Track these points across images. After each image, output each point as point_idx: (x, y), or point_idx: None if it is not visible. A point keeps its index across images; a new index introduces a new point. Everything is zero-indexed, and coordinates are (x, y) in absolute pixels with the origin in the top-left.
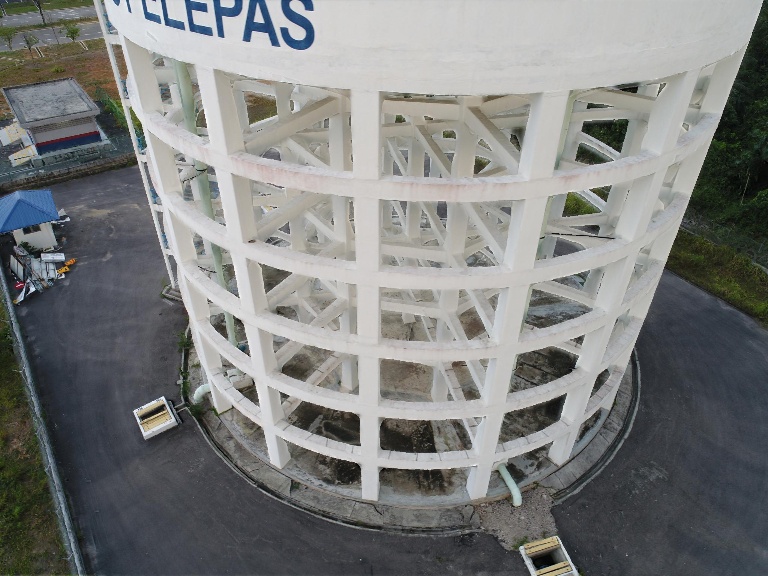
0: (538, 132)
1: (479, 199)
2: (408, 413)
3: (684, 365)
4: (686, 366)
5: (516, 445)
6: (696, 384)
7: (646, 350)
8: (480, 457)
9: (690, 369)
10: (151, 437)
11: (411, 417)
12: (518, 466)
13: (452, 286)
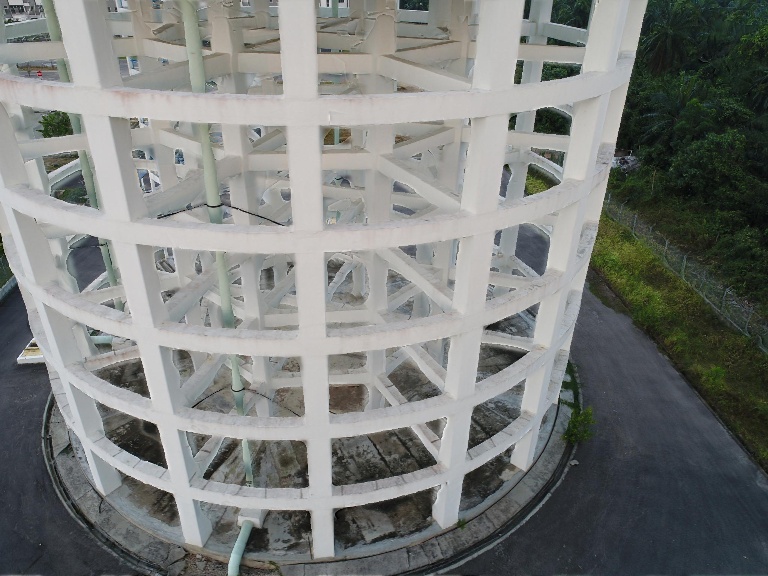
0: (59, 18)
1: (35, 104)
2: (85, 386)
3: (616, 527)
4: (618, 529)
5: (221, 489)
6: (611, 557)
7: (576, 486)
8: (172, 483)
9: (620, 535)
10: (23, 363)
11: (89, 393)
12: (270, 535)
13: (57, 221)
